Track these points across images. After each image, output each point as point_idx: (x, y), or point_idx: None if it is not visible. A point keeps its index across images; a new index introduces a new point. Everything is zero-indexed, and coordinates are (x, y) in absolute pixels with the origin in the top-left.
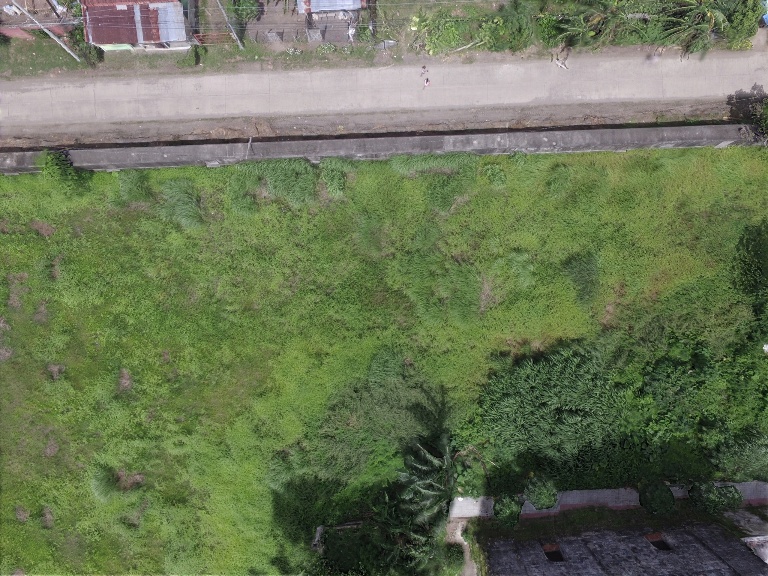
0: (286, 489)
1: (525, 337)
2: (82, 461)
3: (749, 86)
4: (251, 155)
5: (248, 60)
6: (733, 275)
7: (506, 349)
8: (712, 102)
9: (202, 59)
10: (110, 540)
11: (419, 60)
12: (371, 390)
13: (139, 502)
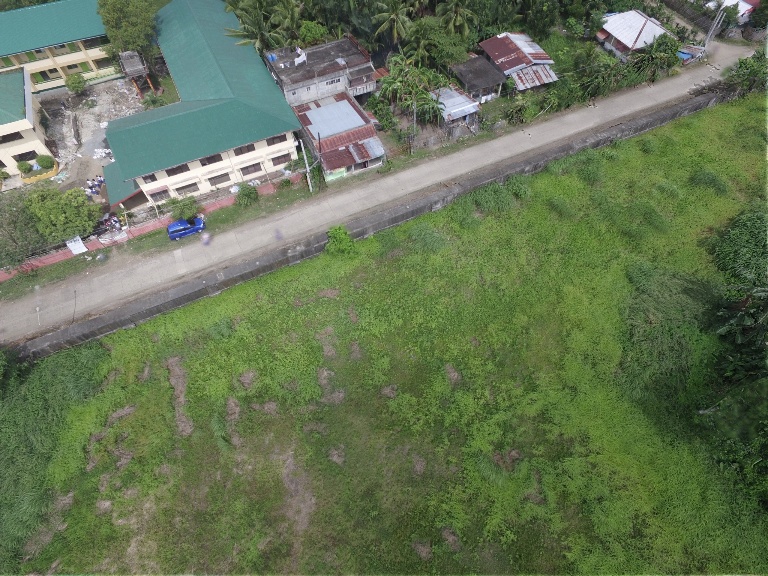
0: (648, 393)
1: (708, 226)
2: (454, 463)
3: (693, 86)
4: (463, 189)
5: (419, 158)
6: None
7: (704, 236)
8: (683, 96)
9: (391, 166)
10: (526, 534)
11: (517, 129)
12: (646, 292)
13: (532, 473)
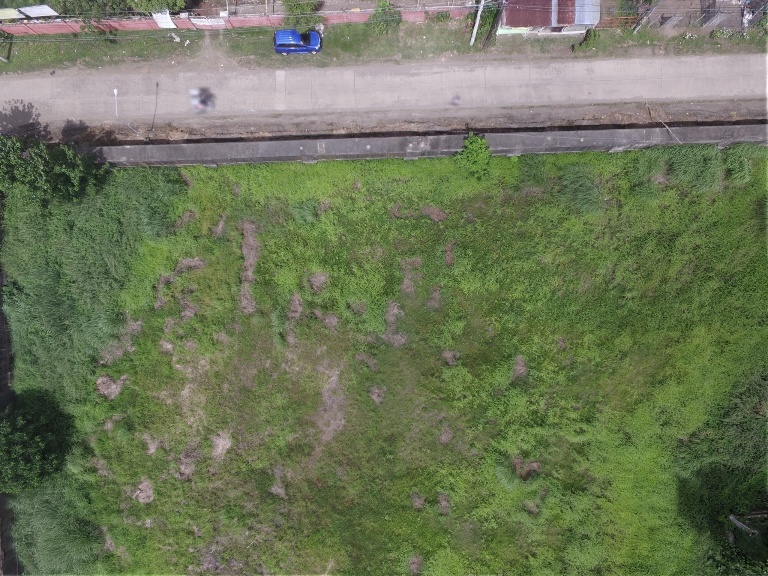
0: (697, 477)
1: None
2: (477, 448)
3: None
4: (668, 140)
5: (640, 45)
6: None
7: None
8: None
9: (595, 43)
10: (506, 527)
11: None
12: None
13: (540, 489)
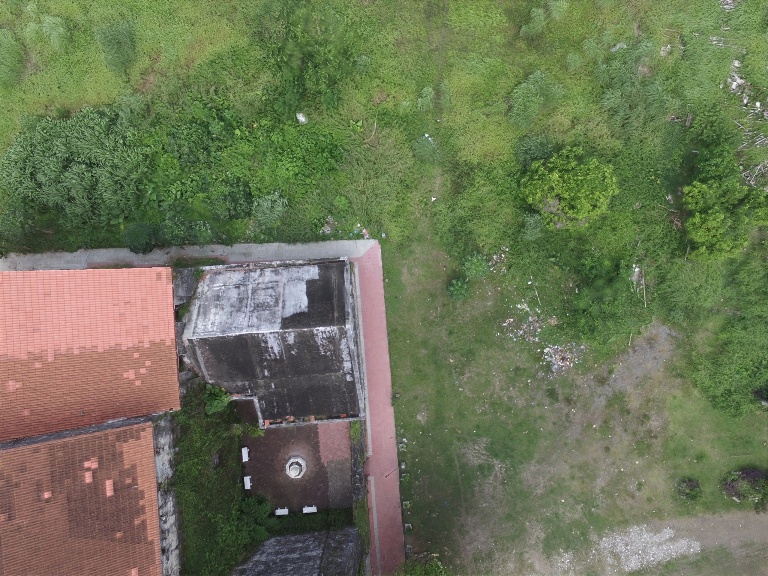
0: None
1: (62, 102)
2: None
3: None
4: None
5: None
6: (266, 44)
7: (42, 112)
8: None
9: None
10: None
11: None
12: None
13: None
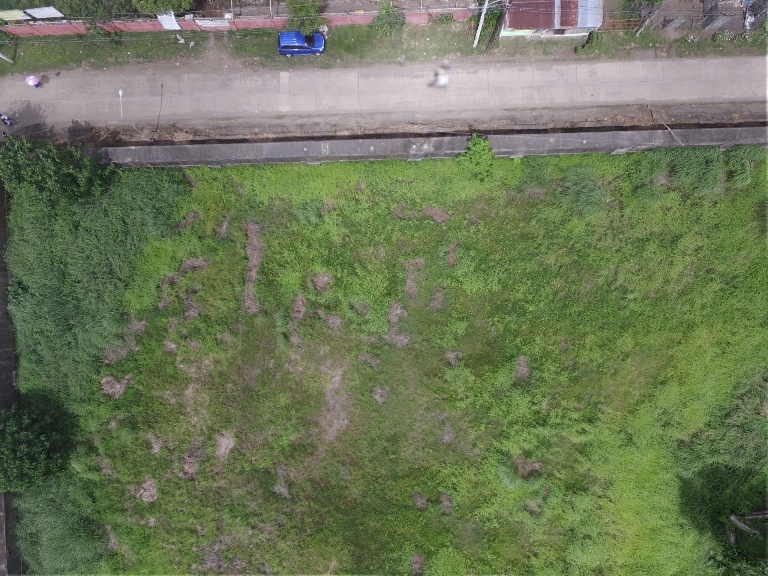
0: (698, 478)
1: None
2: (480, 448)
3: None
4: (671, 142)
5: (643, 47)
6: None
7: None
8: None
9: (598, 46)
10: (508, 527)
11: None
12: None
13: (542, 490)
